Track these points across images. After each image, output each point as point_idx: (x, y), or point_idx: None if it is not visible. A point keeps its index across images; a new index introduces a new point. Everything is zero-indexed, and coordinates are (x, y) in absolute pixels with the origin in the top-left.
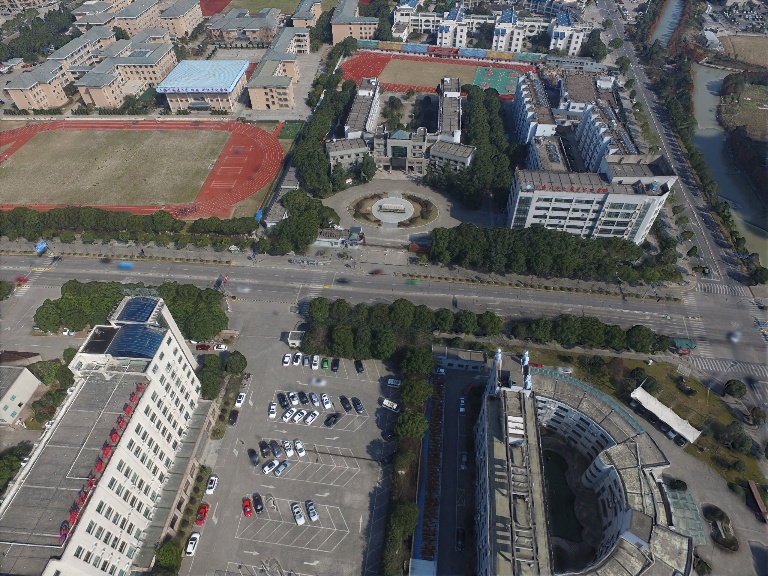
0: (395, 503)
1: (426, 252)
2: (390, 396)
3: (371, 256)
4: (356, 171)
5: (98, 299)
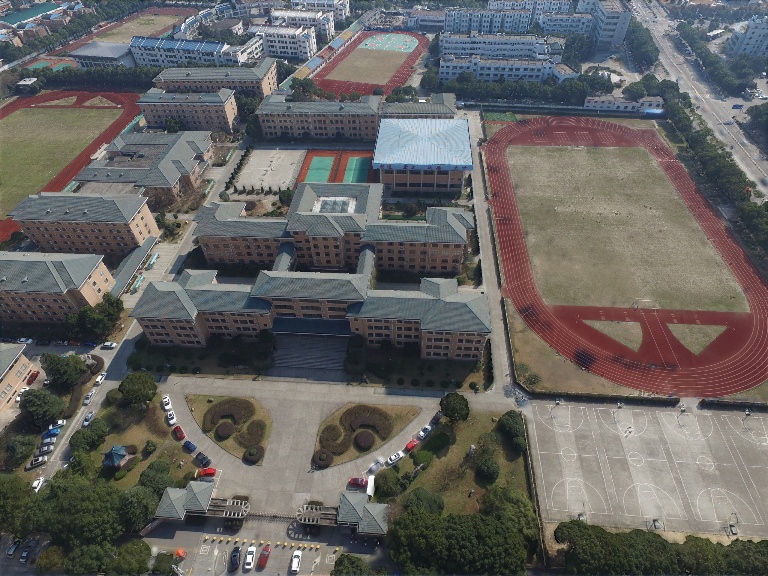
0: None
1: None
2: None
3: None
4: None
5: None
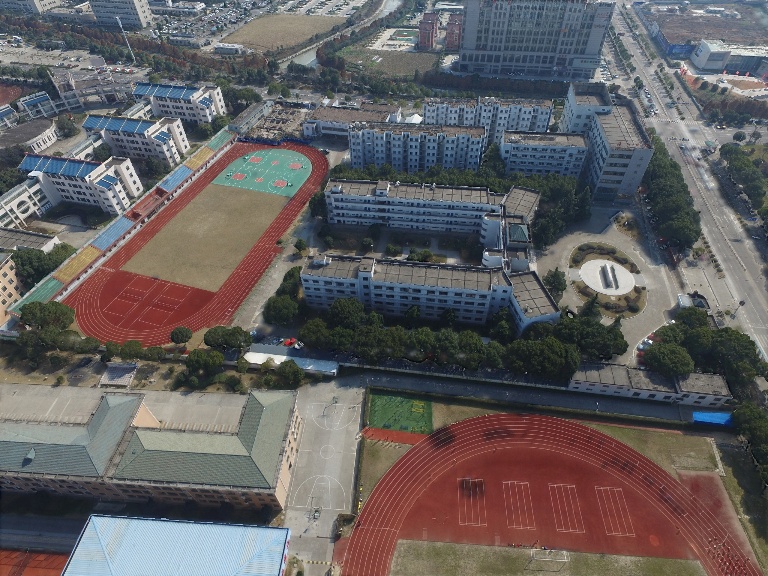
0: None
1: None
2: None
3: None
4: None
5: None
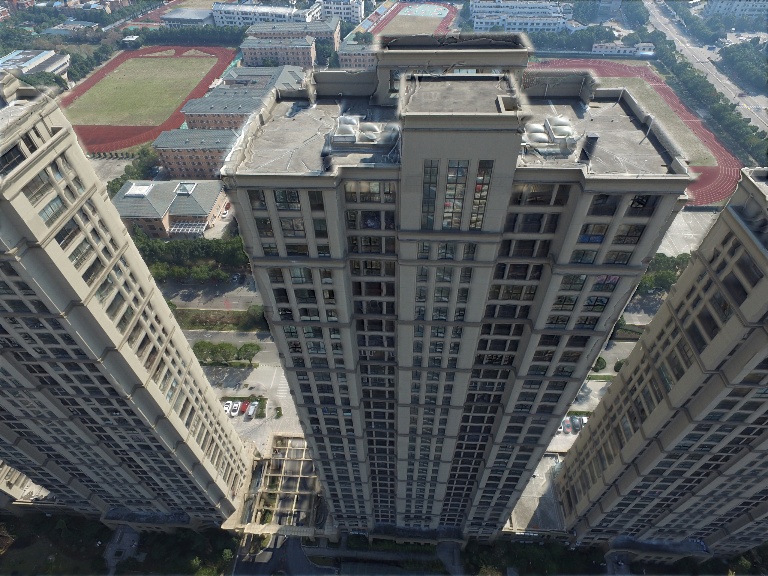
0: None
1: None
2: None
3: None
4: None
5: (764, 63)
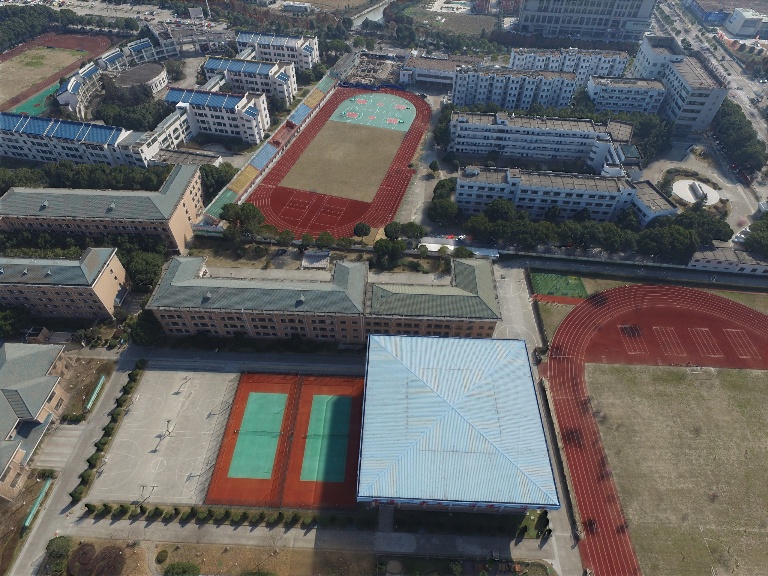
0: None
1: None
2: None
3: None
4: None
5: None
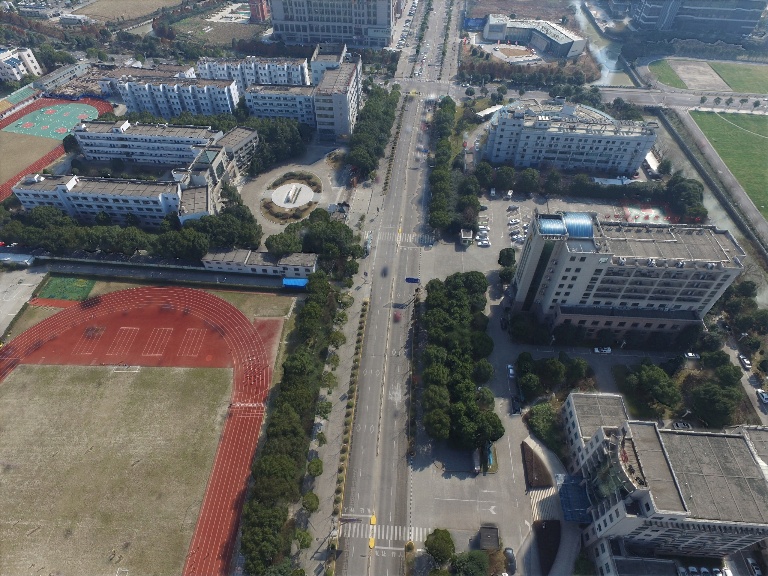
0: (577, 183)
1: (359, 177)
2: (501, 196)
3: (360, 207)
4: (226, 211)
5: None
